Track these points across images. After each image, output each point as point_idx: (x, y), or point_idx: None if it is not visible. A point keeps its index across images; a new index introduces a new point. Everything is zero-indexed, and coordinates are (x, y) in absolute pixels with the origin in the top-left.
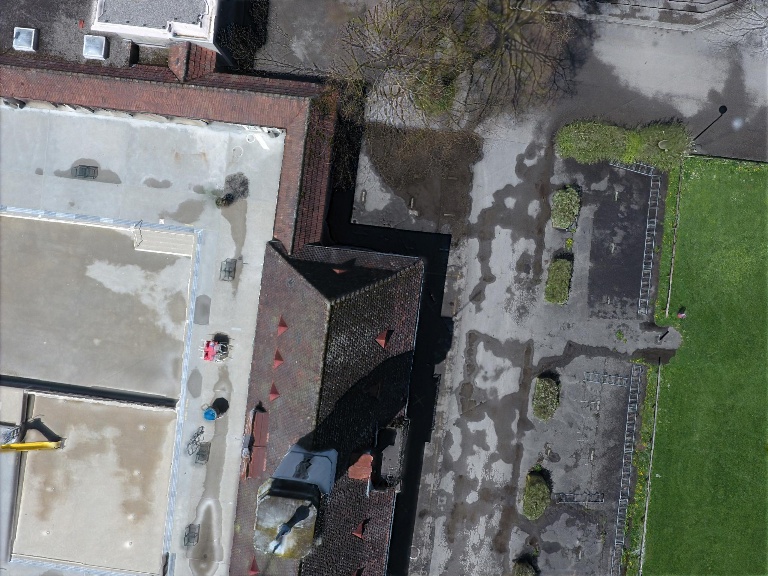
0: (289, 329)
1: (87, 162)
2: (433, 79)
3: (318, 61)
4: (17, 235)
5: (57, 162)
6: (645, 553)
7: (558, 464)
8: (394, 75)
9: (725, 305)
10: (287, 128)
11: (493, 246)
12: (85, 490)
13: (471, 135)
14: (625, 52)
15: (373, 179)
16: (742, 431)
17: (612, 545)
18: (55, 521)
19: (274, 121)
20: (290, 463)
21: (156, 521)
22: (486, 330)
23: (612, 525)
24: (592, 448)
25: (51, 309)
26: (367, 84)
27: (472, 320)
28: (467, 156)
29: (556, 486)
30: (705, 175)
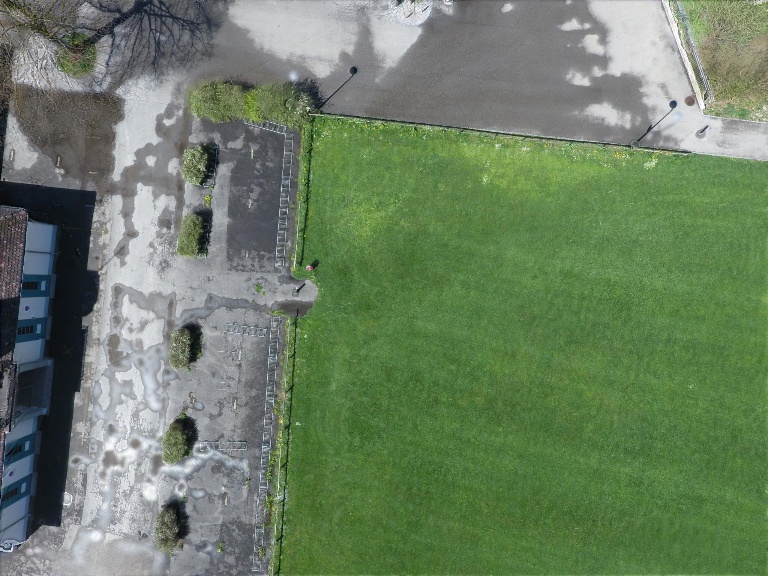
0: None
1: None
2: (73, 42)
3: None
4: None
5: None
6: (288, 499)
7: (202, 413)
8: (39, 39)
9: (357, 258)
10: None
11: (136, 202)
12: None
13: (112, 96)
14: (259, 16)
15: (21, 139)
16: (375, 380)
17: (257, 491)
18: None
19: None
20: None
21: None
22: (131, 283)
23: (256, 472)
24: (235, 397)
25: None
26: (14, 48)
27: (117, 274)
28: (109, 116)
29: (201, 434)
30: (336, 133)
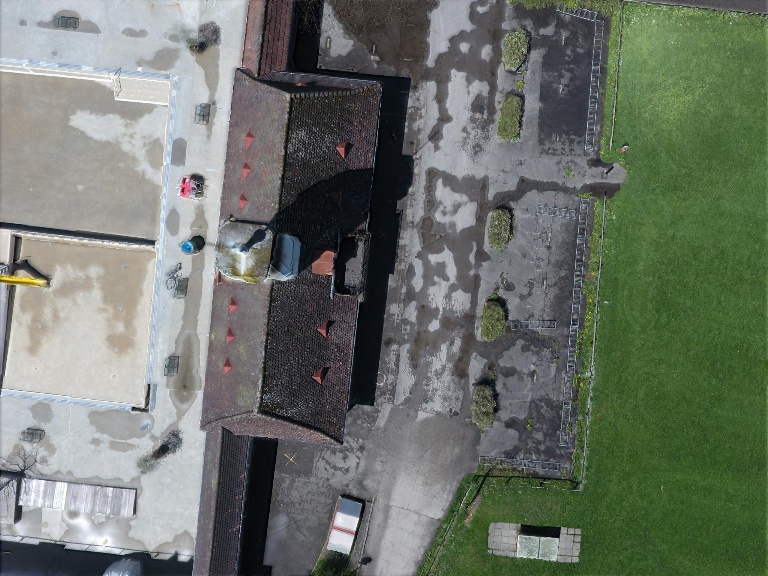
0: (256, 138)
1: (68, 13)
2: None
3: None
4: (3, 88)
5: (40, 14)
6: (595, 375)
7: (513, 293)
8: None
9: (665, 141)
10: None
11: (450, 88)
12: (70, 327)
13: None
14: None
15: (337, 27)
16: (682, 258)
17: (564, 369)
18: (42, 357)
19: None
20: None
21: (138, 355)
22: (444, 167)
23: (564, 350)
24: (544, 277)
25: (36, 158)
26: None
27: (431, 158)
28: (424, 4)
29: (512, 314)
30: (645, 20)
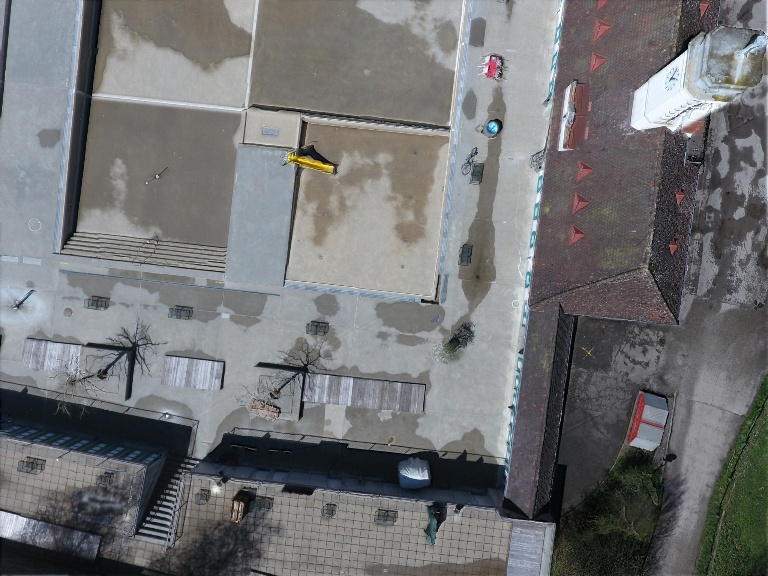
0: None
1: None
2: None
3: None
4: None
5: None
6: None
7: None
8: None
9: None
10: None
11: None
12: (357, 215)
13: None
14: None
15: None
16: None
17: None
18: (328, 246)
19: None
20: None
21: (428, 244)
22: None
23: None
24: None
25: (321, 40)
26: None
27: None
28: None
29: None
30: None
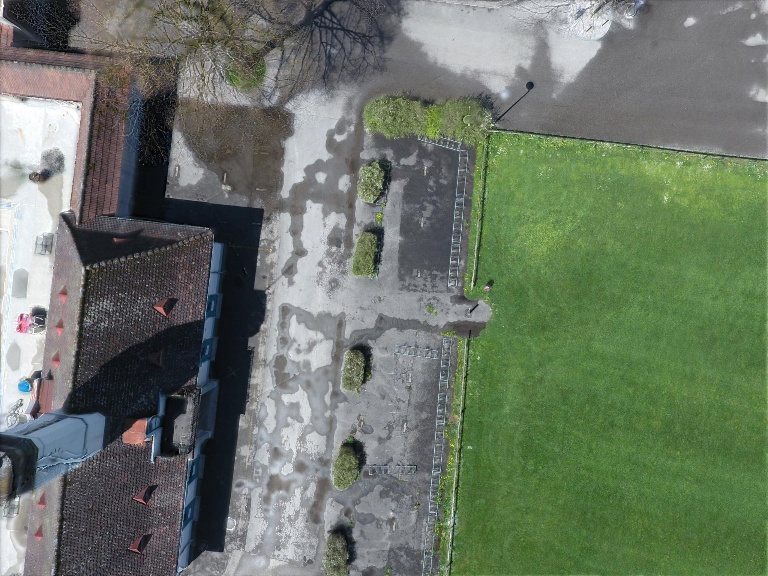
0: (67, 296)
1: None
2: (243, 55)
3: (131, 38)
4: None
5: None
6: (458, 524)
7: (371, 436)
8: (206, 52)
9: (533, 278)
10: (82, 101)
11: (305, 220)
12: None
13: (282, 111)
14: (433, 29)
15: (186, 154)
16: (551, 403)
17: (426, 516)
18: None
19: (69, 94)
20: (32, 423)
21: None
22: (299, 303)
23: (425, 496)
24: (404, 420)
25: None
26: (180, 60)
27: (285, 293)
28: (278, 131)
29: (369, 458)
30: (512, 150)
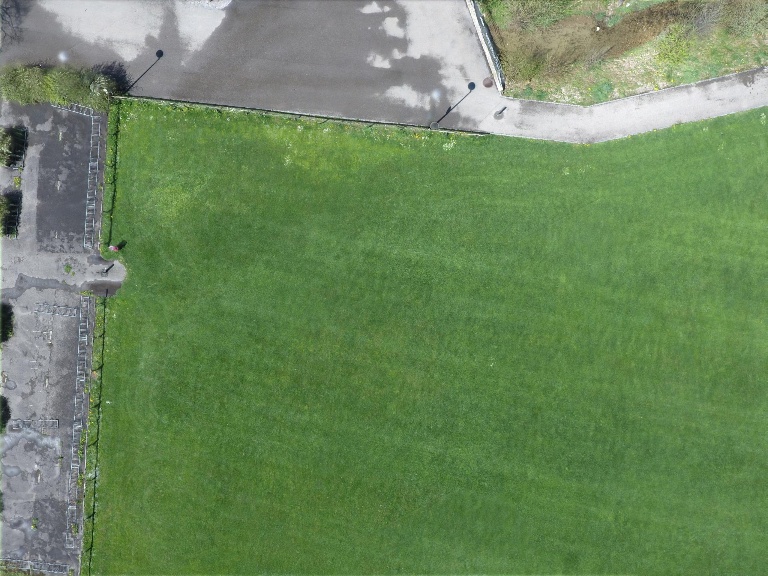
0: None
1: None
2: None
3: None
4: None
5: None
6: (99, 476)
7: (15, 391)
8: None
9: (163, 239)
10: None
11: None
12: None
13: None
14: (66, 0)
15: None
16: (182, 359)
17: (69, 469)
18: None
19: None
20: None
21: None
22: None
23: (68, 450)
24: (46, 376)
25: None
26: None
27: None
28: None
29: (14, 412)
30: (143, 116)
